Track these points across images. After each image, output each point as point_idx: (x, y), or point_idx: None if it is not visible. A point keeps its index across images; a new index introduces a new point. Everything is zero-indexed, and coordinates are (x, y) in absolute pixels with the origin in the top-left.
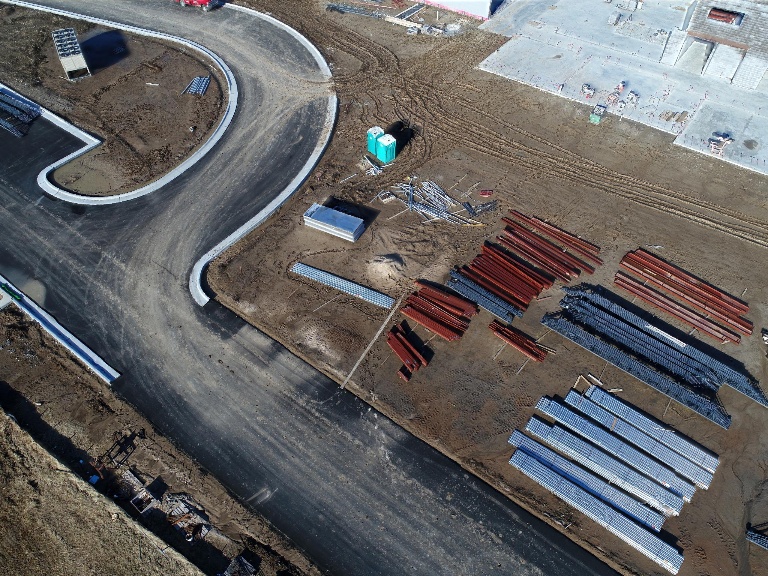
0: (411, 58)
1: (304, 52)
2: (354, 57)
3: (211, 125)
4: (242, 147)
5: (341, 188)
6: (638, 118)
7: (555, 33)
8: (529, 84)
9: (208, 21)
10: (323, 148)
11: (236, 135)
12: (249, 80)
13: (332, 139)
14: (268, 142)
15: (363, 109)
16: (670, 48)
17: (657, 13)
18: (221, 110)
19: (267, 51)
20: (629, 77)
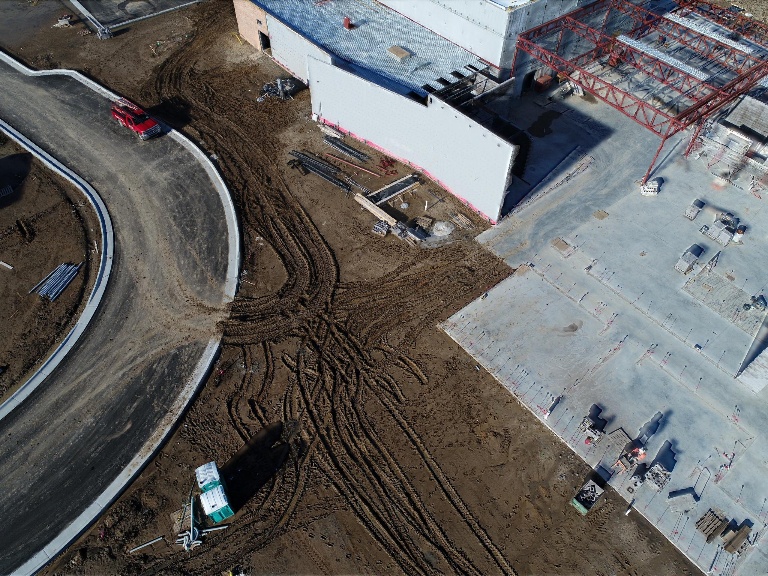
0: (357, 283)
1: (221, 241)
2: (282, 264)
3: (30, 366)
4: (41, 427)
5: (123, 568)
6: (658, 519)
7: (586, 272)
8: (505, 385)
9: (135, 158)
10: (143, 462)
11: (48, 397)
12: (125, 283)
13: (170, 439)
14: (81, 424)
15: (243, 381)
16: (755, 370)
17: (762, 256)
18: (60, 336)
19: (176, 229)
20: (673, 404)
